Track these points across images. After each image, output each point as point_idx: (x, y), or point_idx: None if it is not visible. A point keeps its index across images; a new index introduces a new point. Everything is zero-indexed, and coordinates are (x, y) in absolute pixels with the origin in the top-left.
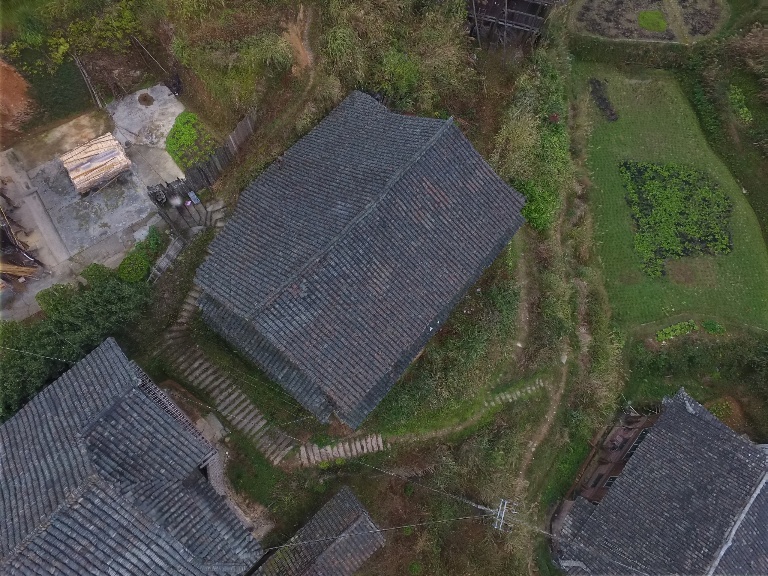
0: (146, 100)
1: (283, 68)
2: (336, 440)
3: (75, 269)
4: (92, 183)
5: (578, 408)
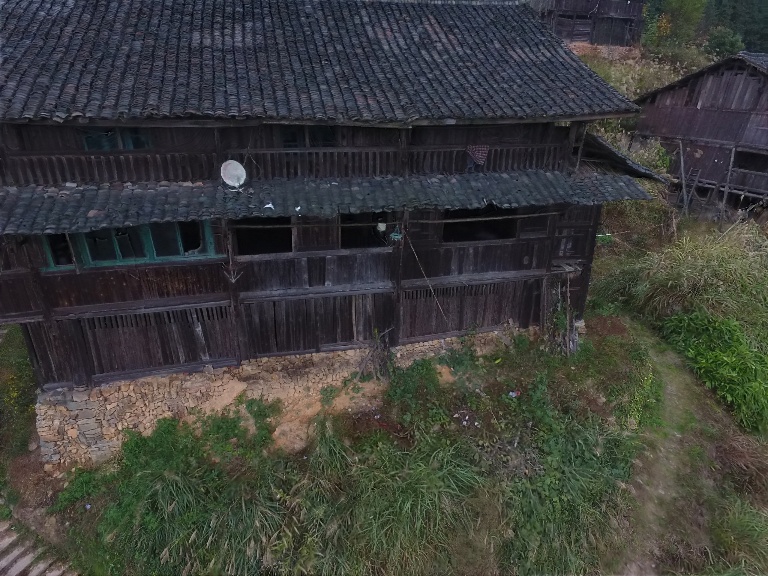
0: None
1: None
2: (6, 504)
3: None
4: None
5: None
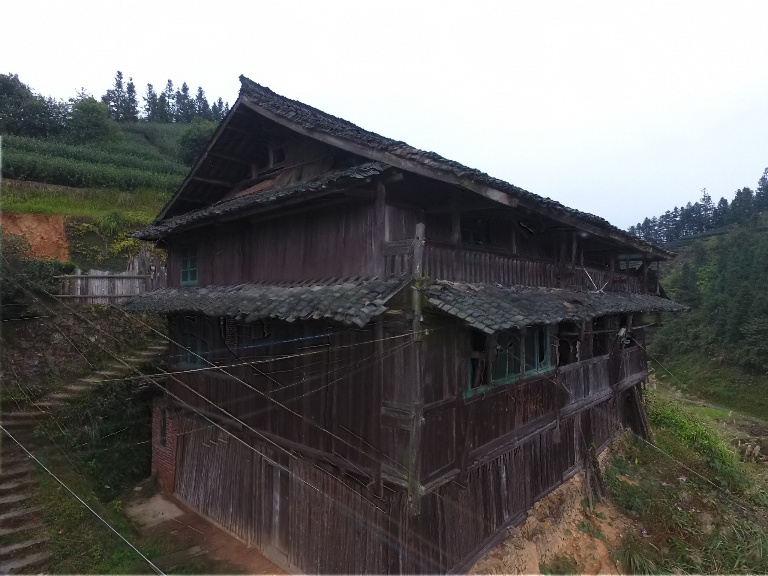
0: None
1: None
2: None
3: None
4: None
5: None
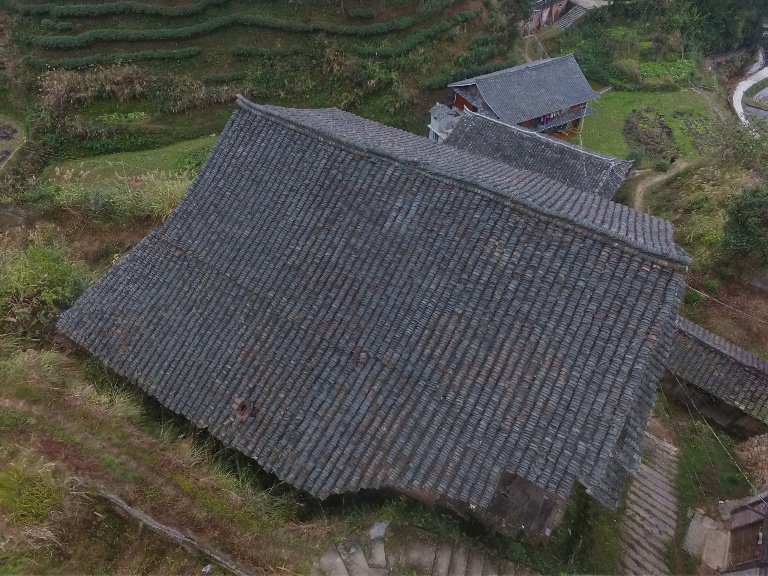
0: None
1: None
2: None
3: None
4: None
5: None
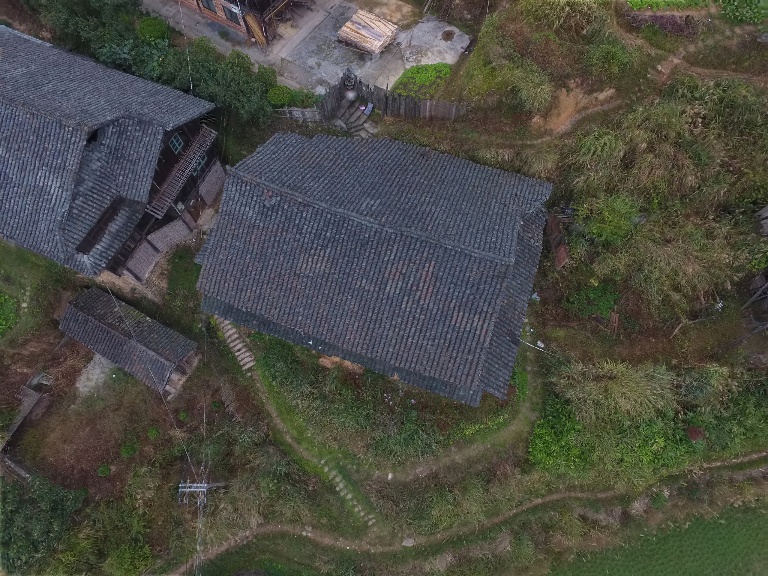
0: (448, 36)
1: (520, 106)
2: None
3: (276, 65)
4: (348, 39)
5: (358, 573)
